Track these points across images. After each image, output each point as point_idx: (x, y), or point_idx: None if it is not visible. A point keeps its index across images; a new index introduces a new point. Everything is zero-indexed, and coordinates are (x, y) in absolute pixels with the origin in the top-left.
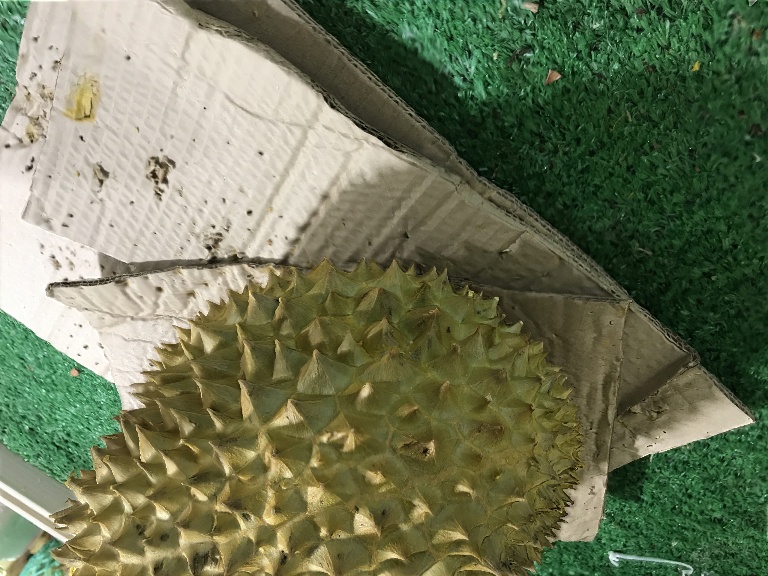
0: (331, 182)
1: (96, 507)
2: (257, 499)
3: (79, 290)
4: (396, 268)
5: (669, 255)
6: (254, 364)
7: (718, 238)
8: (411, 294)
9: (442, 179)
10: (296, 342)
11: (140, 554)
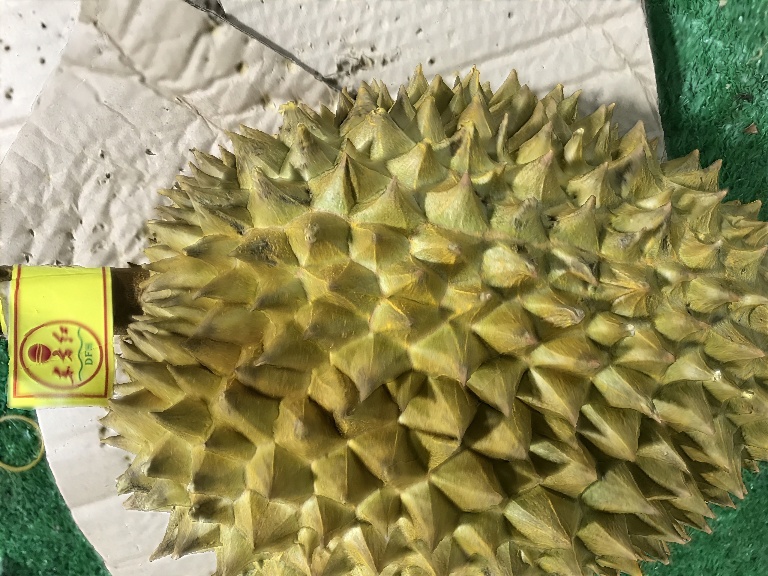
0: (552, 85)
1: (388, 145)
2: (677, 232)
3: None
4: None
5: None
6: None
7: None
8: None
9: (663, 141)
10: None
11: (486, 222)
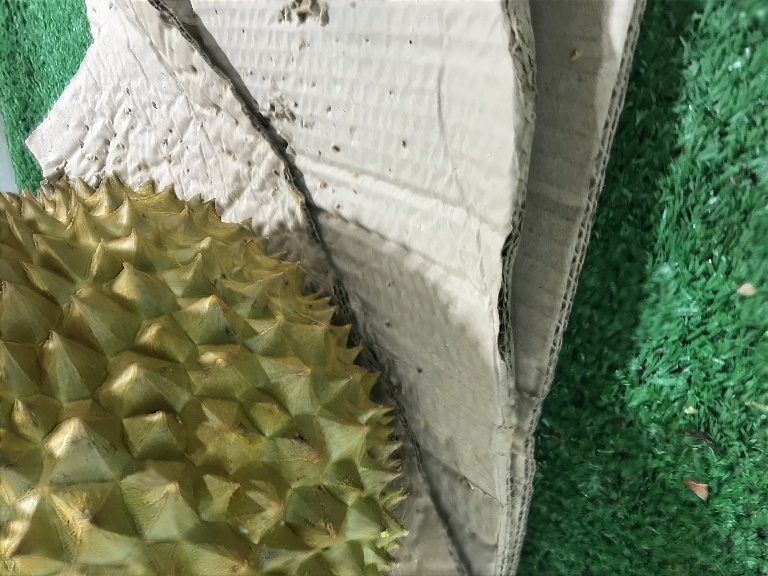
0: (424, 253)
1: None
2: None
3: None
4: (359, 436)
5: None
6: (121, 390)
7: None
8: (341, 472)
9: (500, 411)
10: (190, 402)
11: None
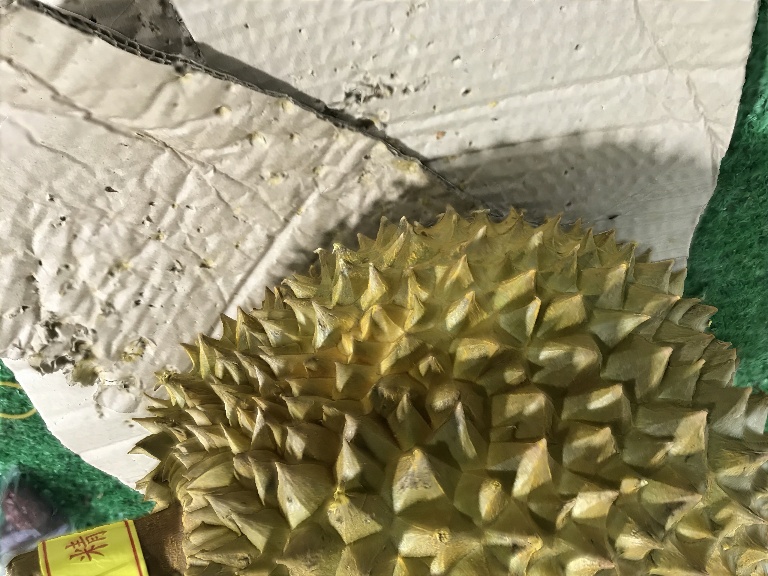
0: (607, 127)
1: (450, 561)
2: None
3: (80, 40)
4: None
5: (709, 304)
6: (659, 377)
7: (746, 306)
8: None
9: (712, 193)
10: None
11: None
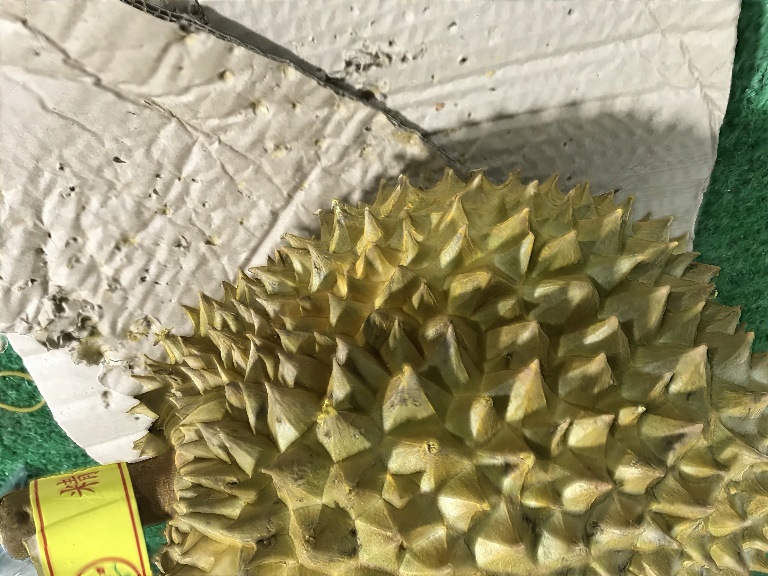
0: (604, 96)
1: (440, 477)
2: None
3: None
4: None
5: None
6: (658, 318)
7: (758, 298)
8: None
9: (713, 165)
10: None
11: (535, 563)
